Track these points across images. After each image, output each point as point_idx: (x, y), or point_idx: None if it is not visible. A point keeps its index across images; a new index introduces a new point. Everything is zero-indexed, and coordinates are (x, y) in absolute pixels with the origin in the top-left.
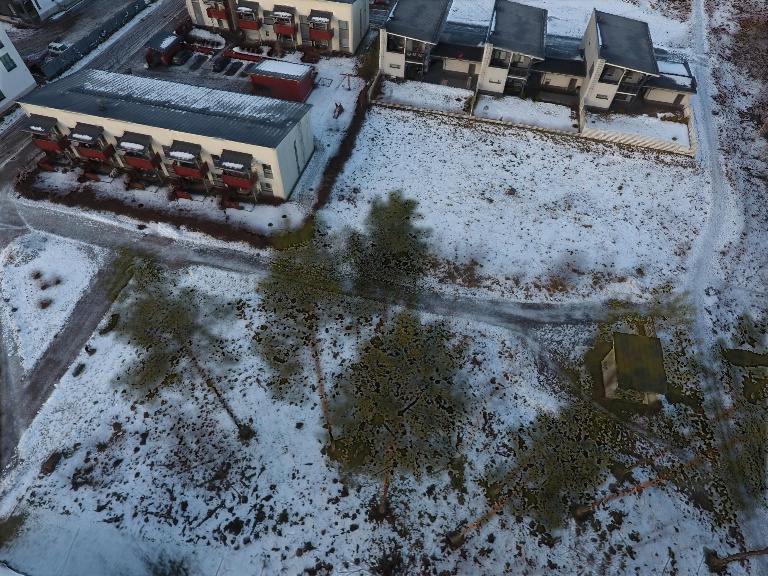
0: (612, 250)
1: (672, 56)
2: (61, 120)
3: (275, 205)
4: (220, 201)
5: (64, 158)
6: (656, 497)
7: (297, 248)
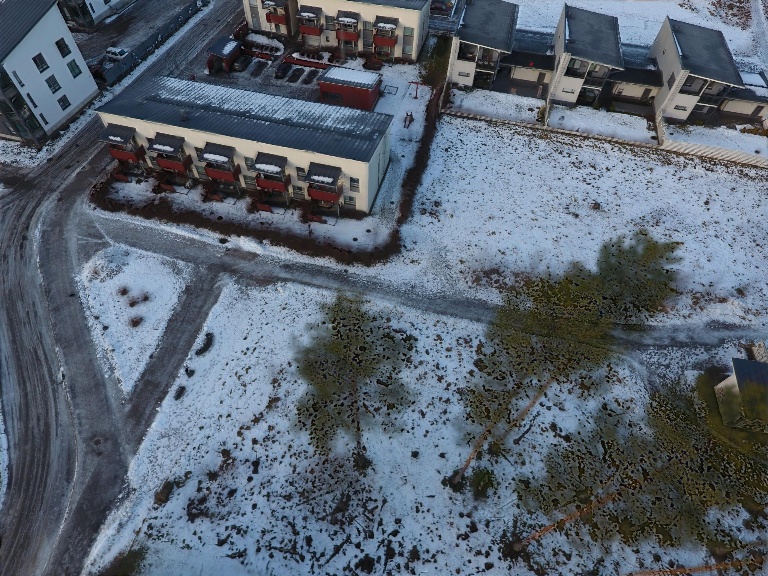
0: (708, 269)
1: (741, 65)
2: (140, 130)
3: (358, 219)
4: (301, 214)
5: (136, 168)
6: None
7: (385, 264)
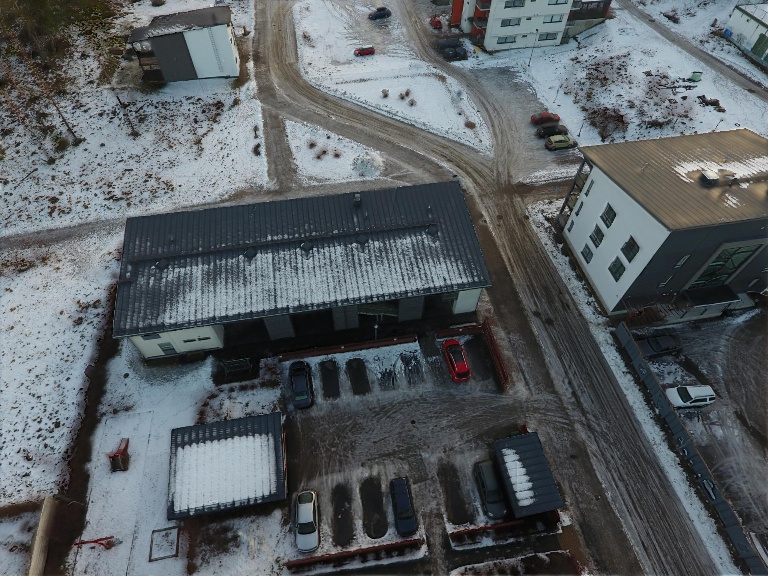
0: None
1: None
2: None
3: None
4: None
5: None
6: None
7: None
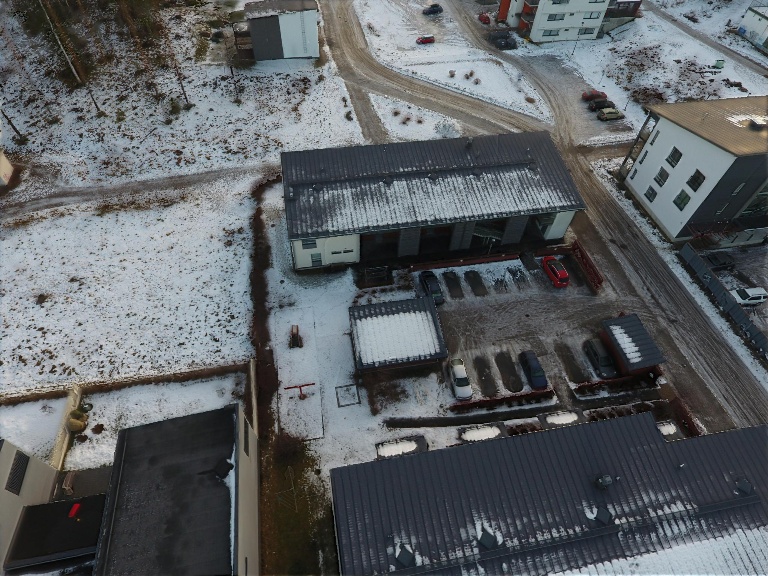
0: None
1: None
2: None
3: None
4: None
5: None
6: (5, 139)
7: None
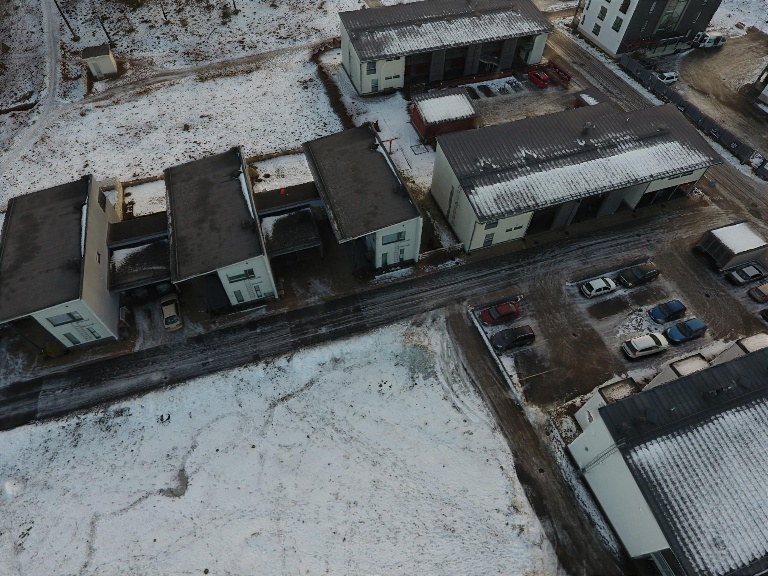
0: (102, 118)
1: None
2: None
3: None
4: None
5: None
6: None
7: None
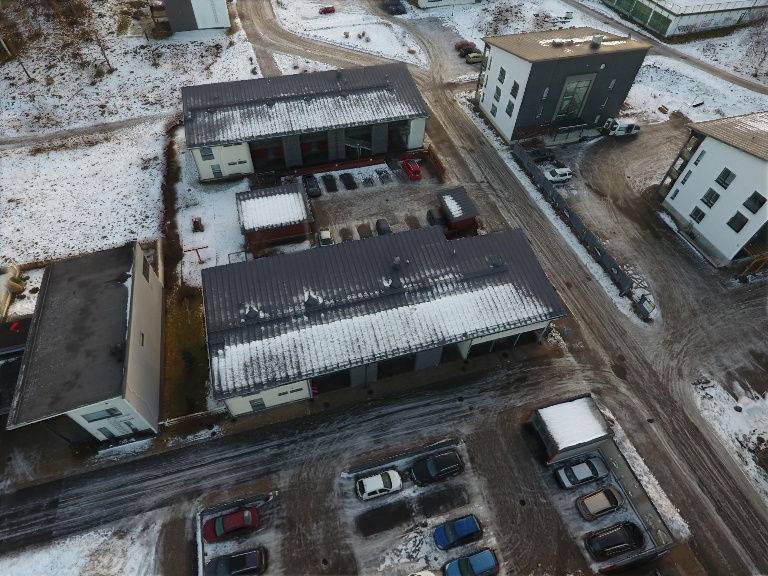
0: None
1: None
2: None
3: None
4: None
5: None
6: None
7: None
